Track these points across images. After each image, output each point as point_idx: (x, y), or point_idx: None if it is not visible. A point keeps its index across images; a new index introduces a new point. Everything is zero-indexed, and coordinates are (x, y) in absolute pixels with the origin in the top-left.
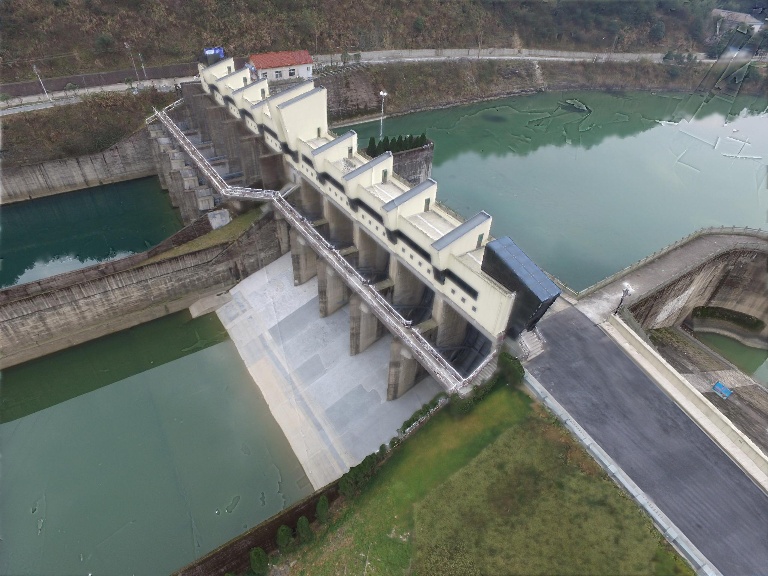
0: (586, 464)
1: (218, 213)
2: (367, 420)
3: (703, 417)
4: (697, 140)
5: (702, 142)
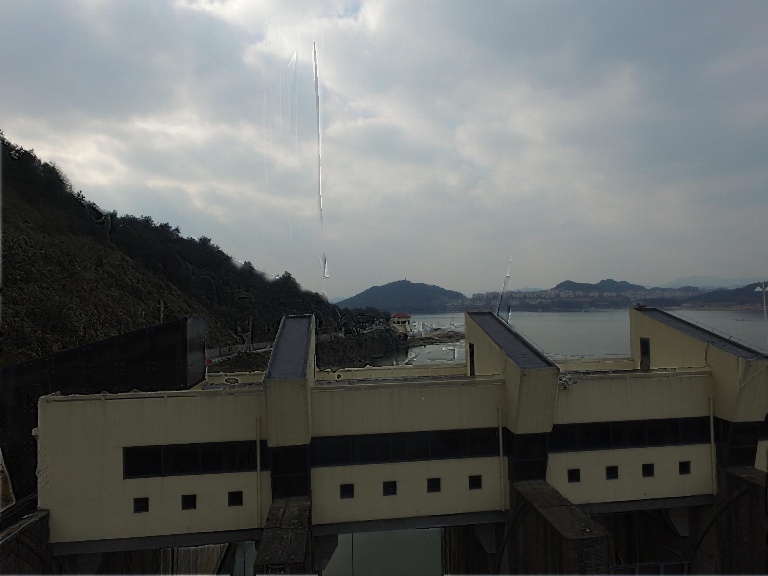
0: None
1: None
2: None
3: None
4: None
5: None
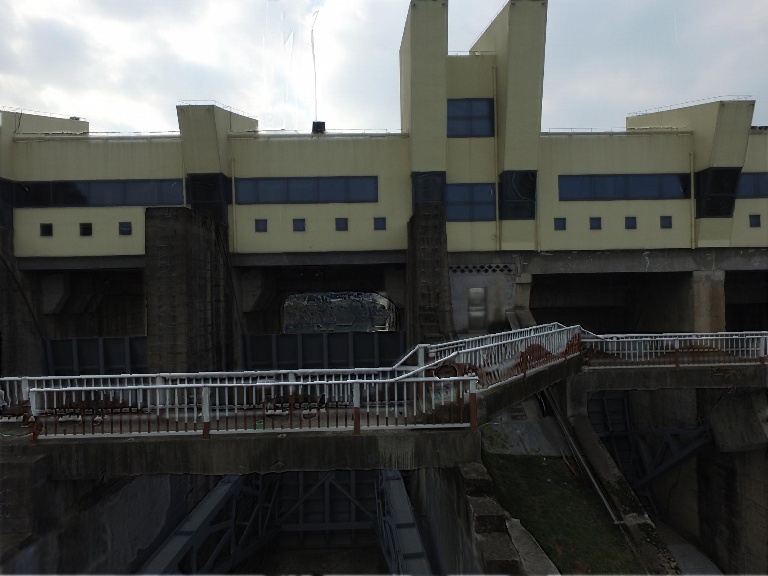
0: None
1: None
2: None
3: None
4: None
5: None
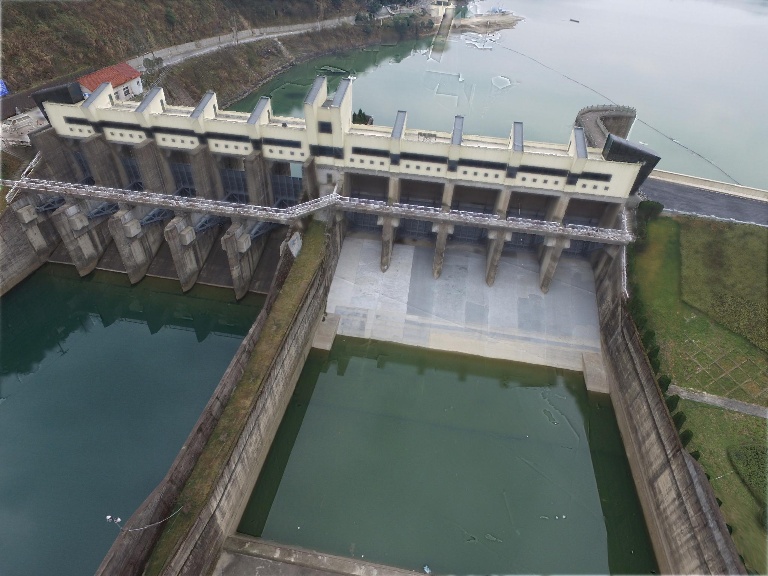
0: (723, 225)
1: (295, 238)
2: (548, 312)
3: (711, 188)
4: (444, 74)
5: (448, 75)
